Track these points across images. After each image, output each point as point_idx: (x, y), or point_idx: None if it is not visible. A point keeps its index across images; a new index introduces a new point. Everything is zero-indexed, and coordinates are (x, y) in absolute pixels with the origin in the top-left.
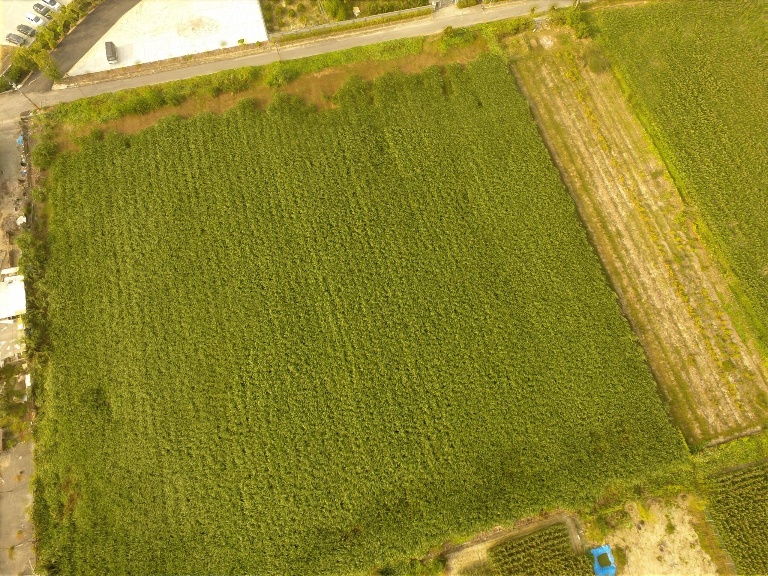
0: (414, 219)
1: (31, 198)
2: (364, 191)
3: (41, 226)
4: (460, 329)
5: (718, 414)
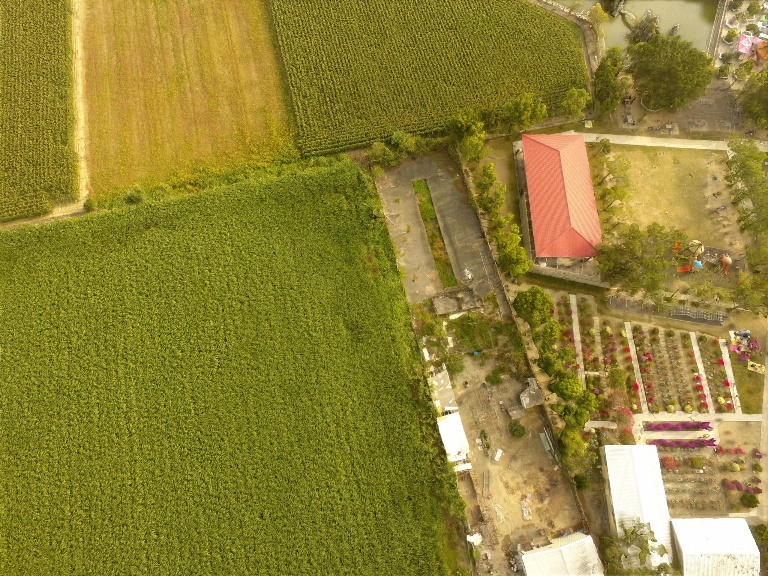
0: (8, 528)
1: (475, 574)
2: (59, 574)
3: (454, 532)
4: (3, 387)
5: None
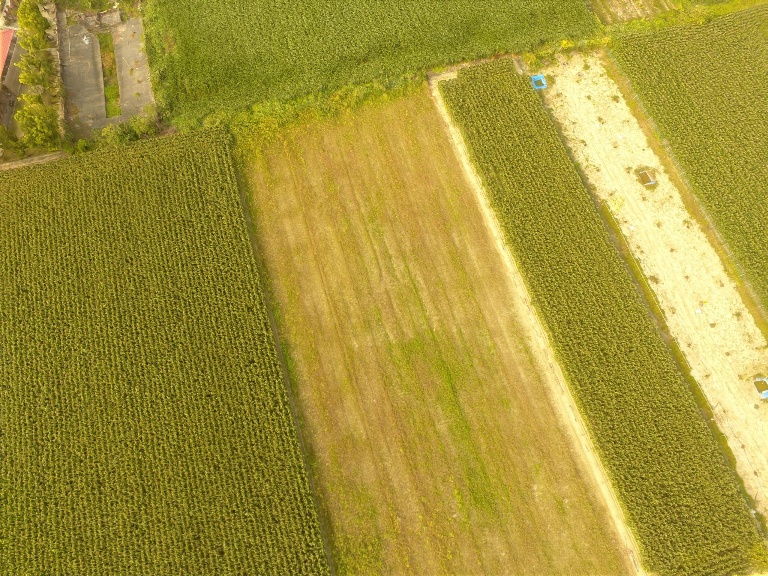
0: None
1: None
2: None
3: None
4: None
5: (625, 11)
